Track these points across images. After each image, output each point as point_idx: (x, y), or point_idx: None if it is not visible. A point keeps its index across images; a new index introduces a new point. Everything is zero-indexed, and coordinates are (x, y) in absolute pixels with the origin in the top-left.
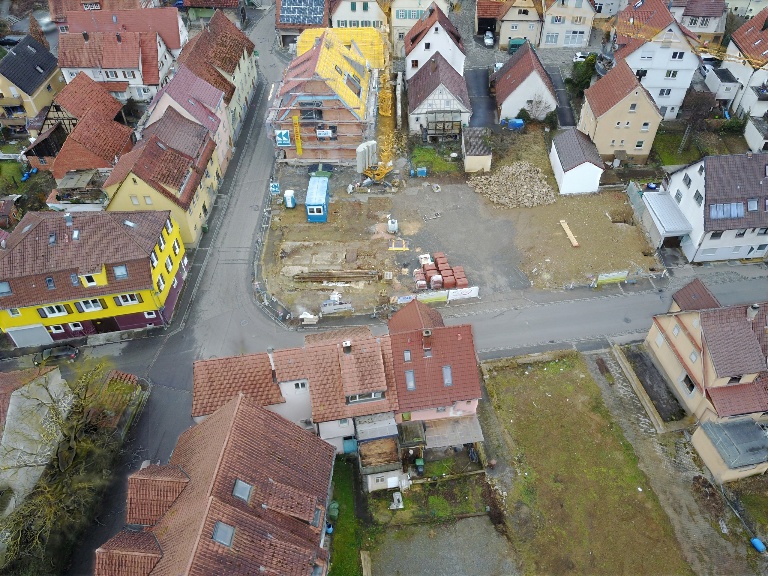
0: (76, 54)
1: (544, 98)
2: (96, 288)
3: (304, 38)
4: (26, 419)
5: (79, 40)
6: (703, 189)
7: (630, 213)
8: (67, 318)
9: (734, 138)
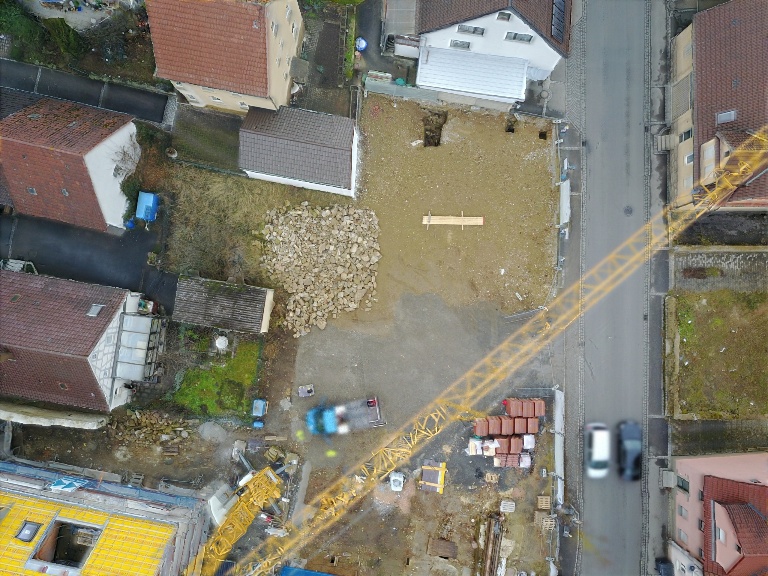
0: None
1: (123, 145)
2: None
3: None
4: None
5: None
6: (526, 30)
7: (415, 108)
8: None
9: None
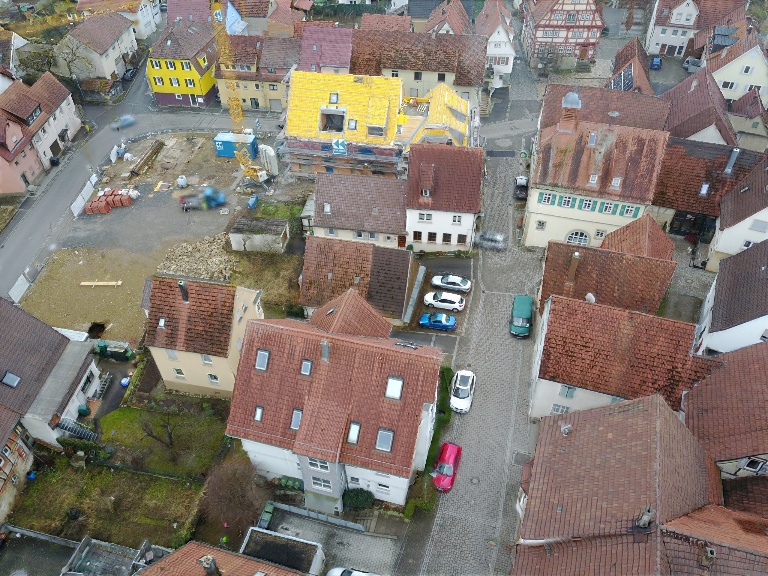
0: None
1: None
2: None
3: None
4: (60, 44)
5: None
6: None
7: None
8: None
9: (164, 546)
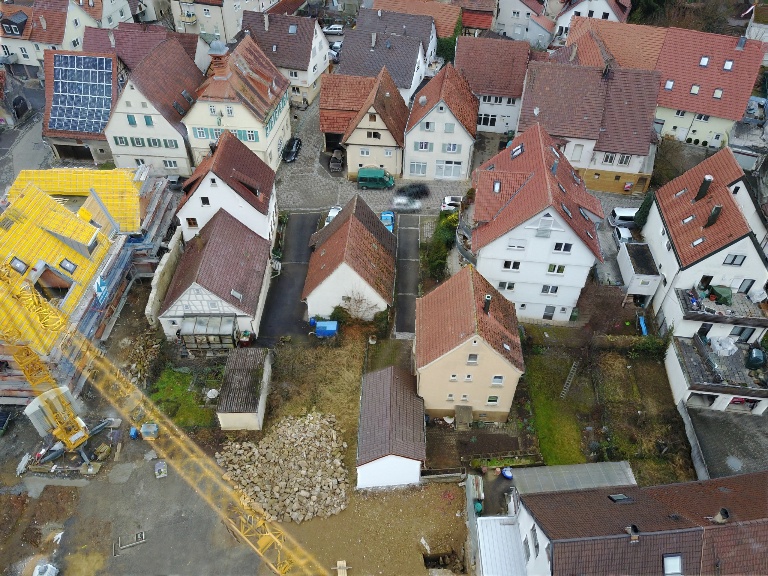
0: None
1: (365, 297)
2: None
3: (19, 184)
4: None
5: None
6: None
7: (462, 537)
8: None
9: (649, 366)
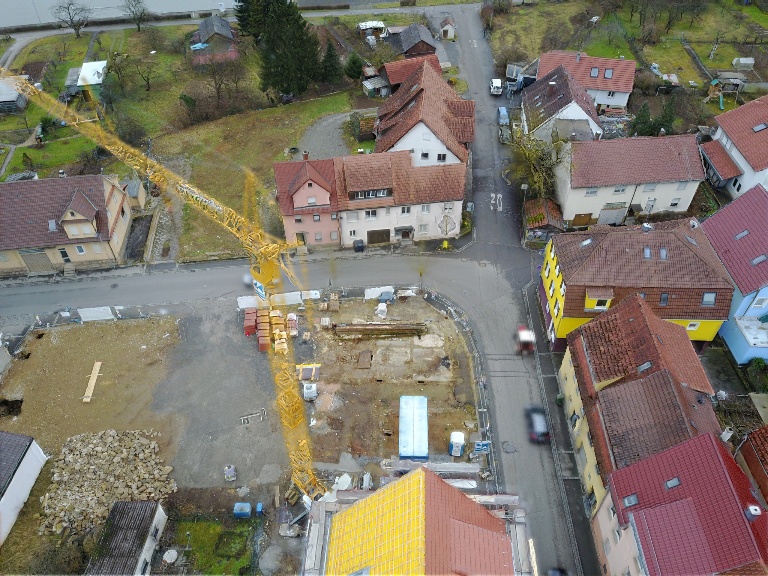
0: None
1: None
2: None
3: None
4: None
5: None
6: None
7: None
8: None
9: None
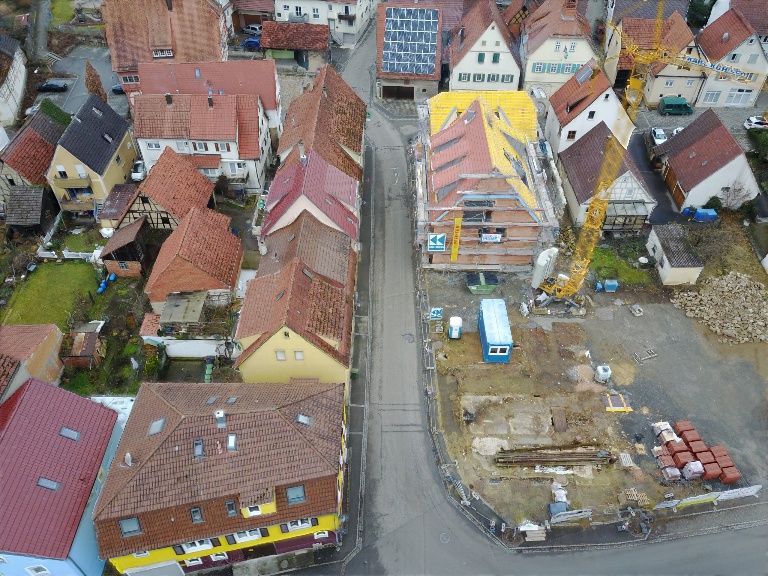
0: (156, 121)
1: (746, 186)
2: (260, 517)
3: (440, 103)
4: None
5: (160, 103)
6: None
7: None
8: (210, 551)
9: None
